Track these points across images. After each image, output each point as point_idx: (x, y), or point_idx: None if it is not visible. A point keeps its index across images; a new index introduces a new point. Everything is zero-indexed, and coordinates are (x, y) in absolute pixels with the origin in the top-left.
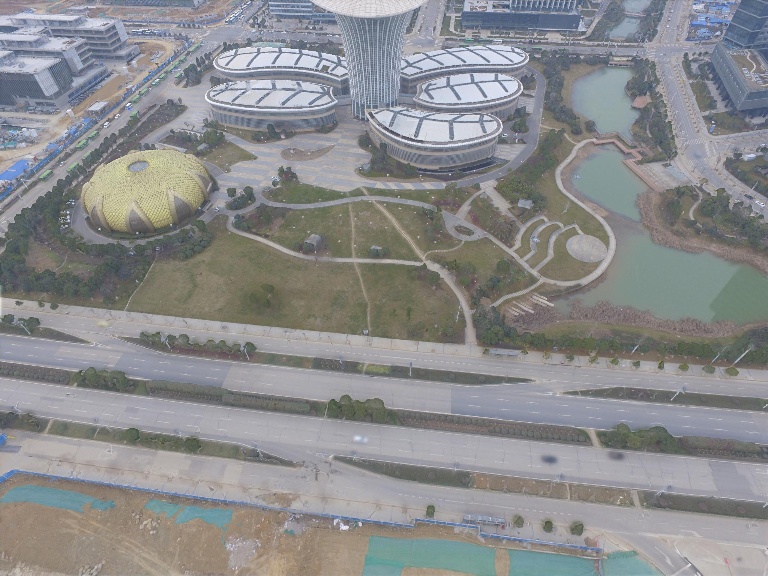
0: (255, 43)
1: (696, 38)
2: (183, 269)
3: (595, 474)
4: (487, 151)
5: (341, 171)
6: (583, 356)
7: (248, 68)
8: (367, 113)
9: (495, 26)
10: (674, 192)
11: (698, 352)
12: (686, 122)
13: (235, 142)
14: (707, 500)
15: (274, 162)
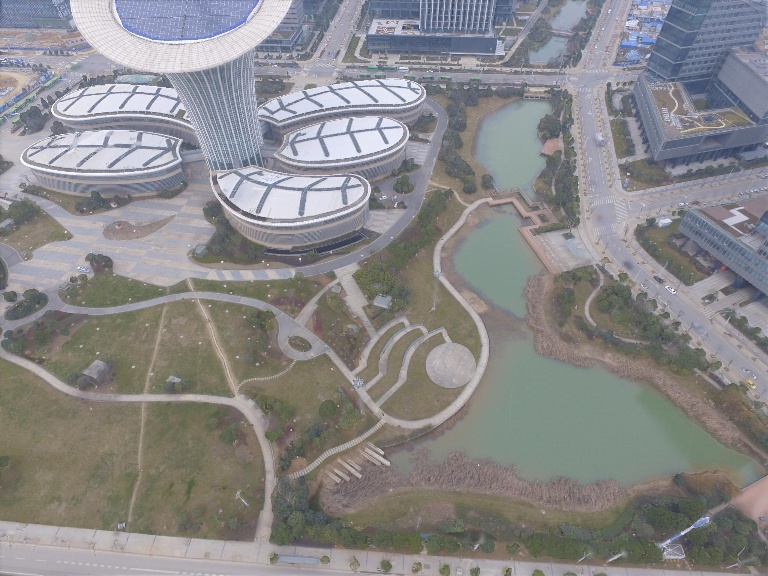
0: (121, 76)
1: (623, 63)
2: None
3: None
4: (352, 224)
5: (170, 254)
6: (410, 555)
7: (89, 114)
8: (211, 177)
9: (404, 50)
10: (568, 278)
11: (556, 555)
12: (599, 173)
13: (53, 214)
14: None
15: (91, 243)
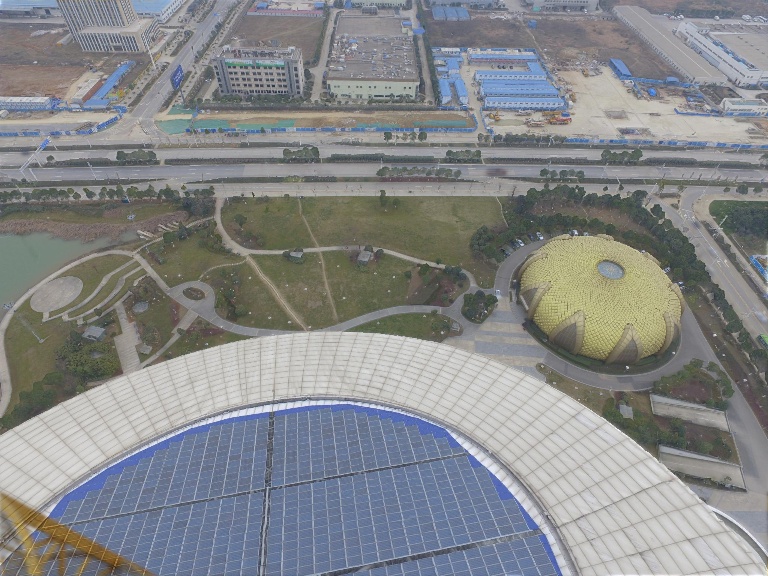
0: None
1: None
2: (476, 224)
3: (172, 152)
4: None
5: None
6: None
7: None
8: None
9: None
10: None
11: None
12: None
13: None
14: (119, 148)
15: None
